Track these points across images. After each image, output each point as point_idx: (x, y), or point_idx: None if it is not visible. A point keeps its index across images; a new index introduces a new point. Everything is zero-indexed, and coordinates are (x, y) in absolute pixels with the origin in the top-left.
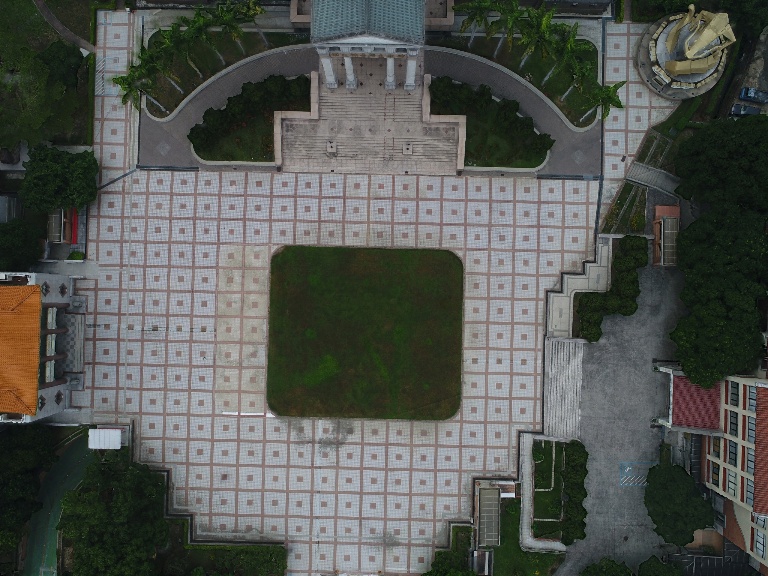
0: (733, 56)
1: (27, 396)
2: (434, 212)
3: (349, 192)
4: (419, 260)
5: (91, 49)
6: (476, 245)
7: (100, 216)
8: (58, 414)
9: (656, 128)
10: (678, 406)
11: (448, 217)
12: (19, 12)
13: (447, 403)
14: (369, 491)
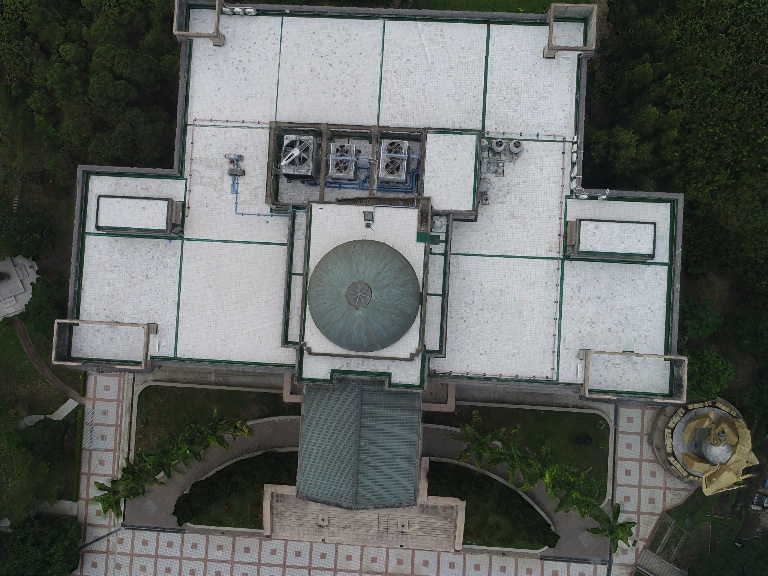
0: (757, 444)
1: None
2: None
3: (340, 564)
4: None
5: (80, 400)
6: None
7: (83, 575)
8: None
9: (671, 513)
10: None
11: None
12: (10, 358)
13: None
14: None
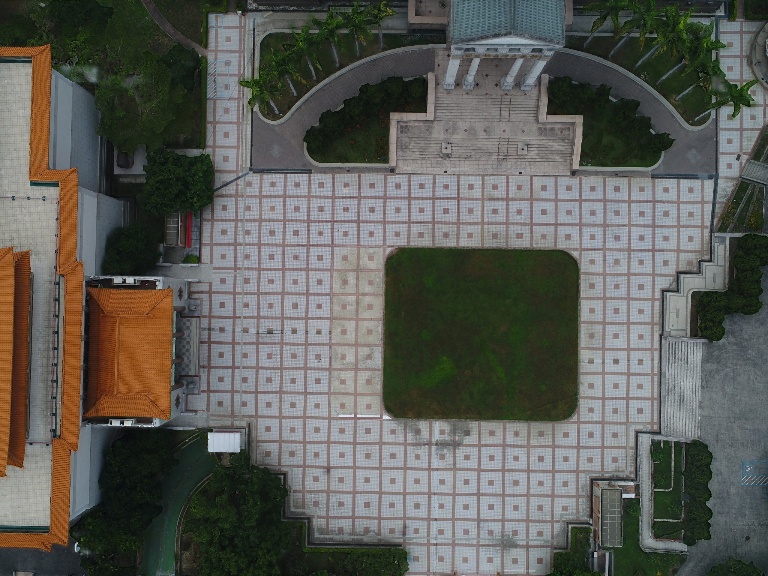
0: None
1: (161, 400)
2: (549, 212)
3: (463, 193)
4: (534, 261)
5: (202, 52)
6: (591, 245)
7: (213, 219)
8: (174, 418)
9: None
10: None
11: (563, 217)
12: (130, 16)
13: (564, 404)
14: (487, 493)
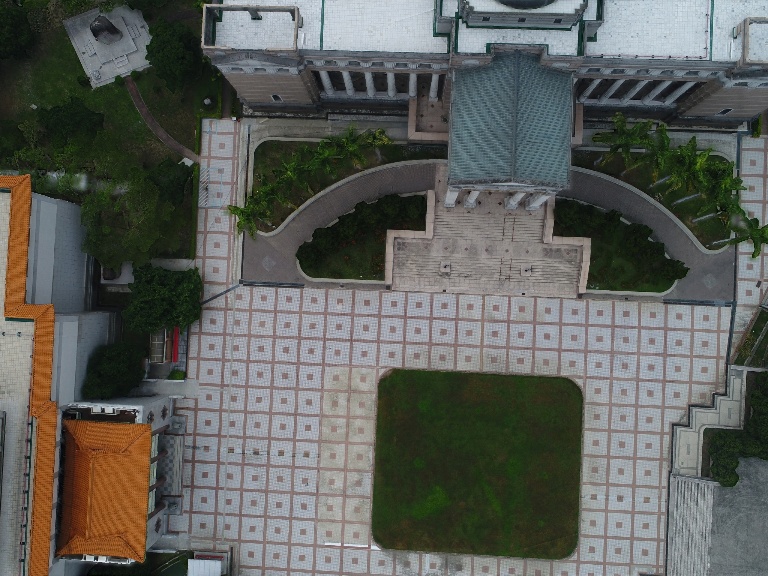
0: None
1: (135, 541)
2: (552, 337)
3: (462, 313)
4: (536, 388)
5: (195, 159)
6: (597, 373)
7: (201, 333)
8: None
9: None
10: None
11: (567, 343)
12: (122, 119)
13: (563, 541)
14: None
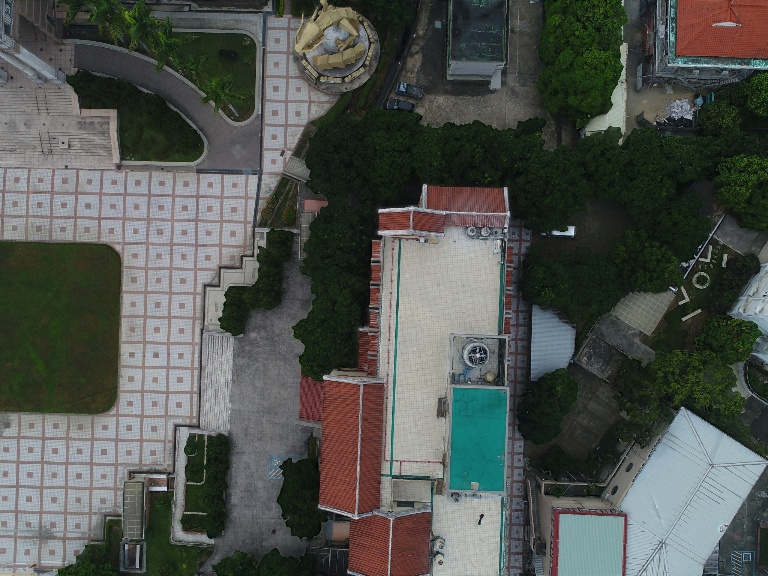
0: (386, 51)
1: None
2: (93, 206)
3: (9, 186)
4: (77, 254)
5: None
6: (134, 239)
7: None
8: None
9: (314, 123)
10: (303, 399)
11: (107, 211)
12: None
13: (103, 397)
14: (25, 484)
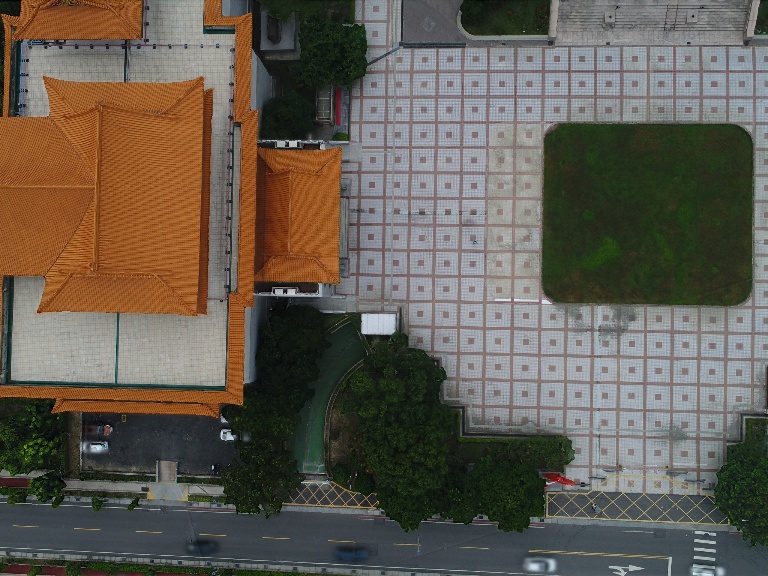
0: None
1: (330, 264)
2: (720, 84)
3: (626, 65)
4: (704, 135)
5: None
6: (766, 119)
7: (363, 96)
8: (323, 302)
9: None
10: None
11: (735, 89)
12: None
13: (737, 287)
14: (653, 381)
